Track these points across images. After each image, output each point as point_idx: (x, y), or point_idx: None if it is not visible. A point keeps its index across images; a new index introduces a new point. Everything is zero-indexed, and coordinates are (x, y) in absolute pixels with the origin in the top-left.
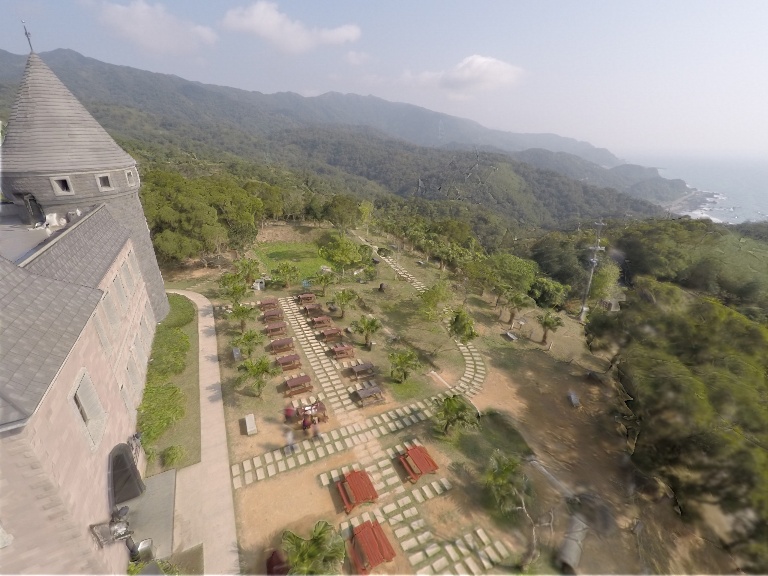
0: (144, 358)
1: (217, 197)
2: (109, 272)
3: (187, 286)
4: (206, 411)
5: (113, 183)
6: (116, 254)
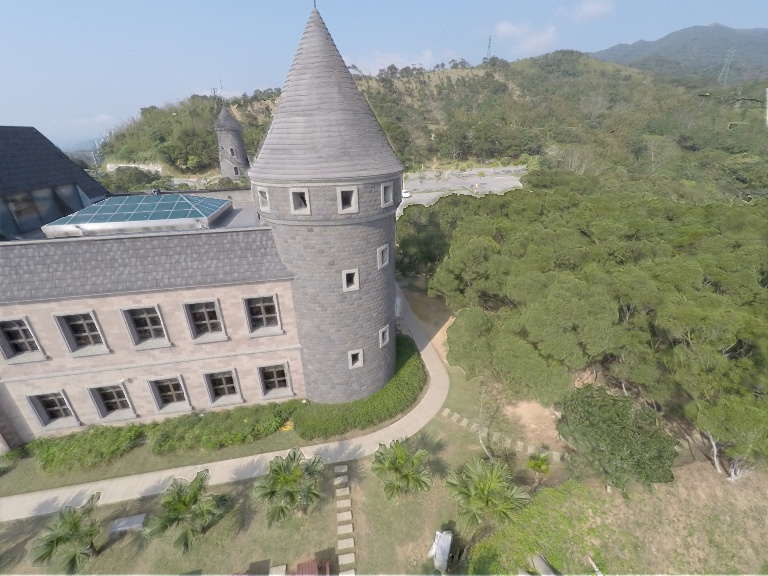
0: (187, 405)
1: (686, 310)
2: (123, 299)
3: (459, 407)
4: (29, 498)
5: (271, 203)
6: (160, 287)
